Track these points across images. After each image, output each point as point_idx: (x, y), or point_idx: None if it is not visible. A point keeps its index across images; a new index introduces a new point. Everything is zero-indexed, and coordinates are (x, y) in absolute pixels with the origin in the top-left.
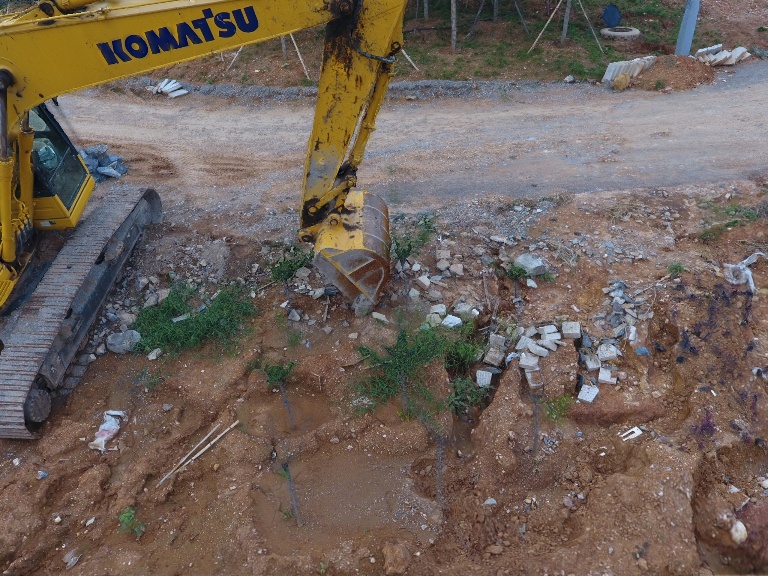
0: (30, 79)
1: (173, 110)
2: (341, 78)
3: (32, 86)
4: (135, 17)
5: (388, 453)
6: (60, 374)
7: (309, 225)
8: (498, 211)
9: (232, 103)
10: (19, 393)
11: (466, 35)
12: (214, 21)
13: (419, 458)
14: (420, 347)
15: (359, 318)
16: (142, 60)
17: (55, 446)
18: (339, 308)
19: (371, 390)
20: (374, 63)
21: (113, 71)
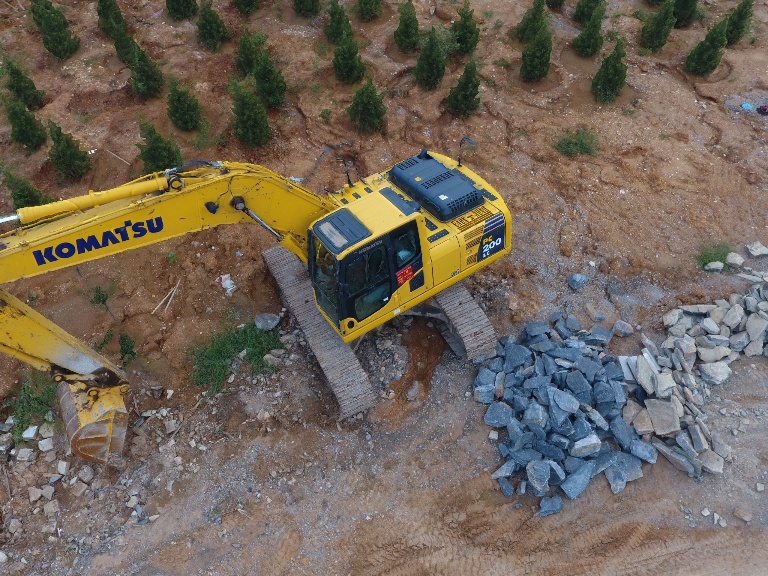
0: None
1: None
2: None
3: None
4: None
5: None
6: None
7: None
8: None
9: None
10: None
11: None
12: None
13: None
14: None
15: None
16: None
17: None
18: None
19: None
20: None
21: None
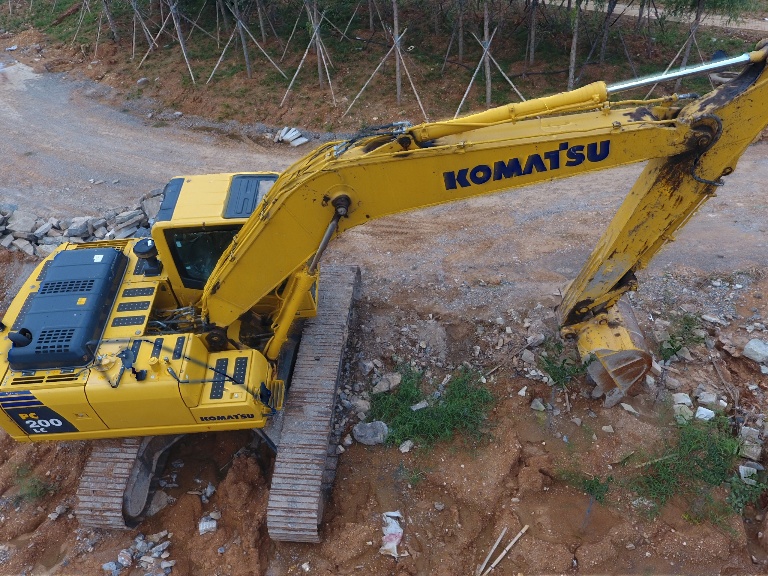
0: (364, 203)
1: None
2: (662, 198)
3: (363, 208)
4: (492, 150)
5: (692, 562)
6: None
7: (572, 322)
8: (698, 286)
9: None
10: (311, 499)
11: (574, 80)
12: (566, 153)
13: (724, 567)
14: (691, 446)
15: (606, 409)
16: (480, 186)
17: (344, 551)
18: (579, 396)
19: (649, 491)
20: (701, 186)
21: (447, 195)
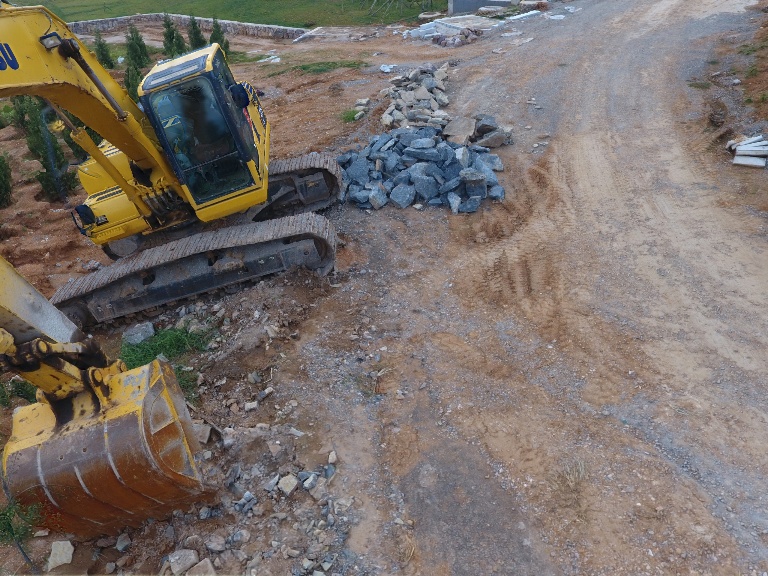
0: None
1: (690, 178)
2: None
3: None
4: None
5: None
6: (108, 316)
7: None
8: None
9: (761, 210)
10: None
11: None
12: None
13: None
14: None
15: None
16: None
17: None
18: None
19: None
20: None
21: None
